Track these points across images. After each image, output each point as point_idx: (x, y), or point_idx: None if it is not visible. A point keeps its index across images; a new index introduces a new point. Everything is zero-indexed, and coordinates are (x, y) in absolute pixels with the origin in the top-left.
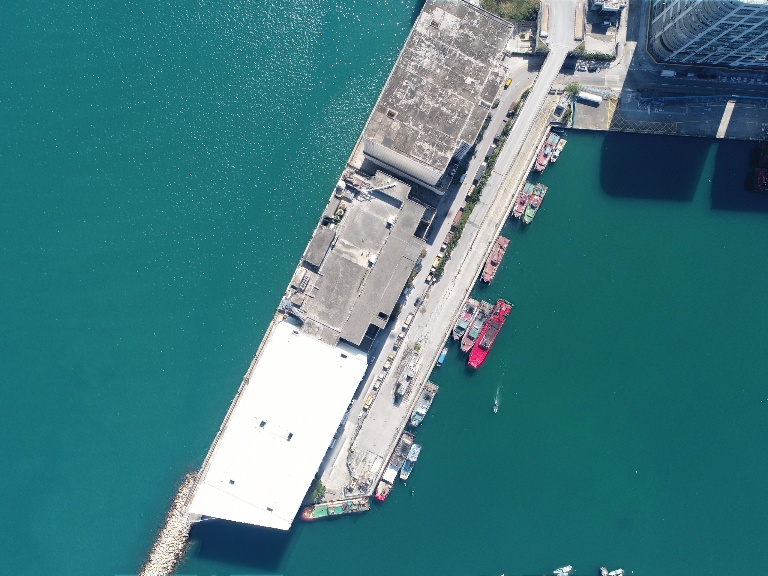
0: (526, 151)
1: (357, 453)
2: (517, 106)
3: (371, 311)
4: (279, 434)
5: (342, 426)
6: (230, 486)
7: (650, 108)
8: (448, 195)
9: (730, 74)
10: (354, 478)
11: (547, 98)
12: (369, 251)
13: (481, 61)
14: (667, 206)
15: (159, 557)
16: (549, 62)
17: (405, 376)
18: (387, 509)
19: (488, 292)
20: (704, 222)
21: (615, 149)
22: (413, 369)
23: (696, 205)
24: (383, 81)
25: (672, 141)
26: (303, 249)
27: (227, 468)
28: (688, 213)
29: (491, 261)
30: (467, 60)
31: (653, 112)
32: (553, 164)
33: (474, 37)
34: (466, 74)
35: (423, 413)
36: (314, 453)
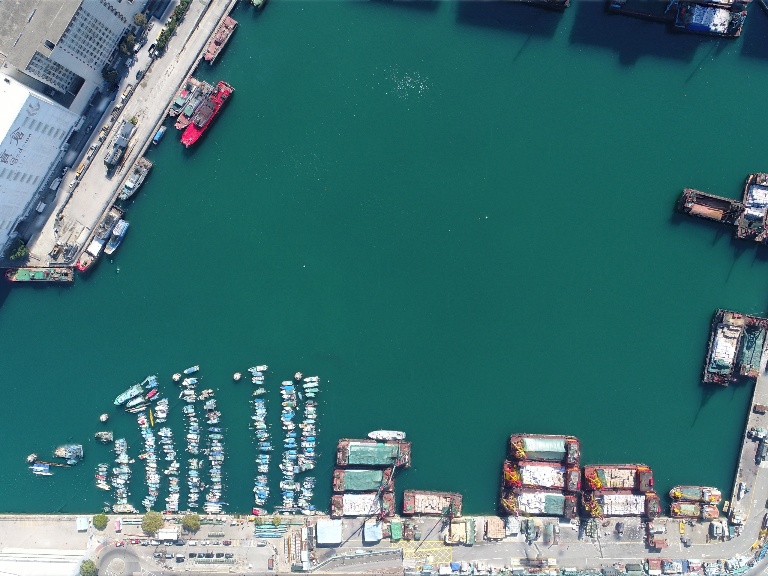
0: None
1: (65, 222)
2: None
3: (39, 39)
4: None
5: (54, 193)
6: None
7: None
8: None
9: None
10: (57, 244)
11: None
12: None
13: None
14: (404, 5)
15: None
16: None
17: (112, 144)
18: (91, 284)
19: (212, 75)
20: (441, 26)
21: None
22: None
23: (435, 7)
24: None
25: None
26: None
27: None
28: (425, 14)
29: (215, 40)
30: None
31: None
32: None
33: None
34: None
35: (130, 186)
36: None
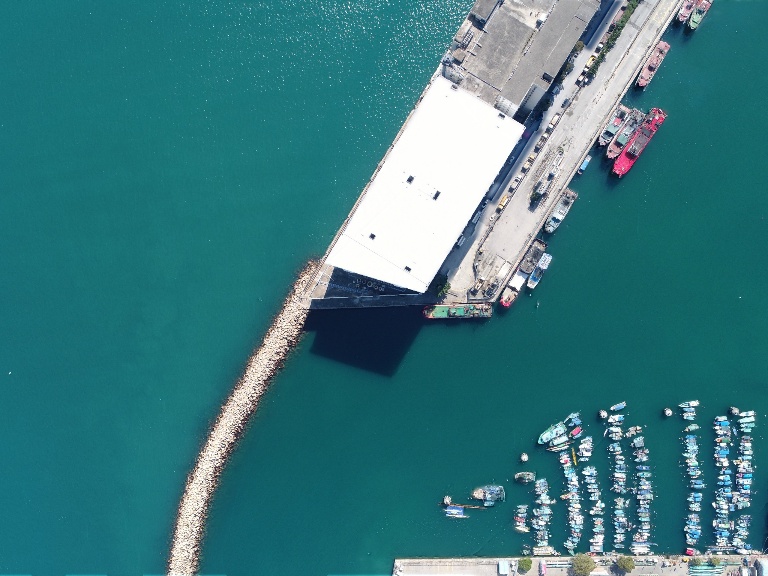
0: None
1: (485, 256)
2: None
3: (535, 71)
4: (426, 191)
5: (472, 226)
6: (370, 241)
7: None
8: None
9: None
10: (480, 279)
11: None
12: (538, 11)
13: None
14: None
15: (273, 341)
16: None
17: (546, 175)
18: (509, 319)
19: (640, 101)
20: None
21: None
22: (557, 166)
23: None
24: None
25: None
26: (451, 40)
27: (369, 222)
28: None
29: (648, 66)
30: None
31: None
32: None
33: None
34: None
35: (560, 219)
36: (460, 215)
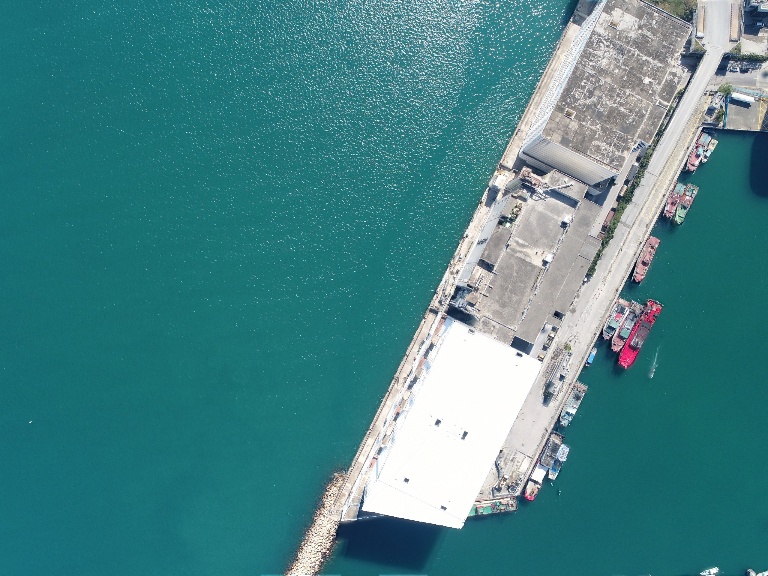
0: (677, 151)
1: (506, 453)
2: (671, 107)
3: (547, 310)
4: (454, 432)
5: None
6: (404, 484)
7: None
8: (599, 195)
9: None
10: (504, 478)
11: None
12: (543, 250)
13: (659, 61)
14: None
15: (308, 556)
16: (705, 63)
17: (558, 376)
18: (534, 509)
19: (637, 292)
20: None
21: (765, 150)
22: (568, 369)
23: None
24: None
25: None
26: (453, 249)
27: (401, 466)
28: None
29: (642, 261)
30: (645, 60)
31: None
32: (703, 165)
33: (652, 37)
34: (644, 74)
35: (573, 413)
36: (488, 452)
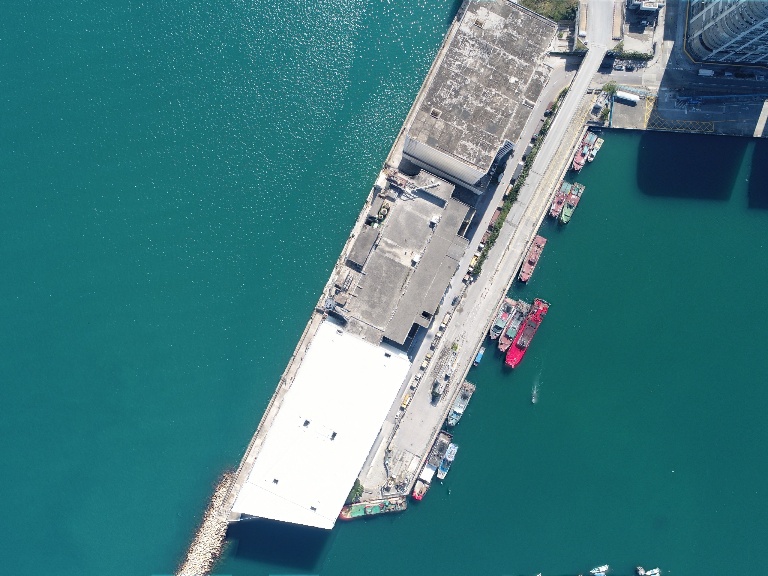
0: (563, 150)
1: (394, 452)
2: (555, 105)
3: (415, 310)
4: (323, 433)
5: None
6: (274, 485)
7: (687, 107)
8: (485, 194)
9: (767, 73)
10: (392, 477)
11: (584, 97)
12: (412, 250)
13: (525, 60)
14: (704, 205)
15: (197, 556)
16: (587, 61)
17: (443, 375)
18: (424, 508)
19: (525, 291)
20: (741, 221)
21: (652, 148)
22: (452, 368)
23: (733, 204)
24: (421, 81)
25: (709, 140)
26: (340, 249)
27: (271, 467)
28: (725, 212)
29: (528, 260)
30: (511, 59)
31: (690, 111)
32: (590, 163)
33: (518, 36)
34: (510, 73)
35: (461, 412)
36: (358, 452)
